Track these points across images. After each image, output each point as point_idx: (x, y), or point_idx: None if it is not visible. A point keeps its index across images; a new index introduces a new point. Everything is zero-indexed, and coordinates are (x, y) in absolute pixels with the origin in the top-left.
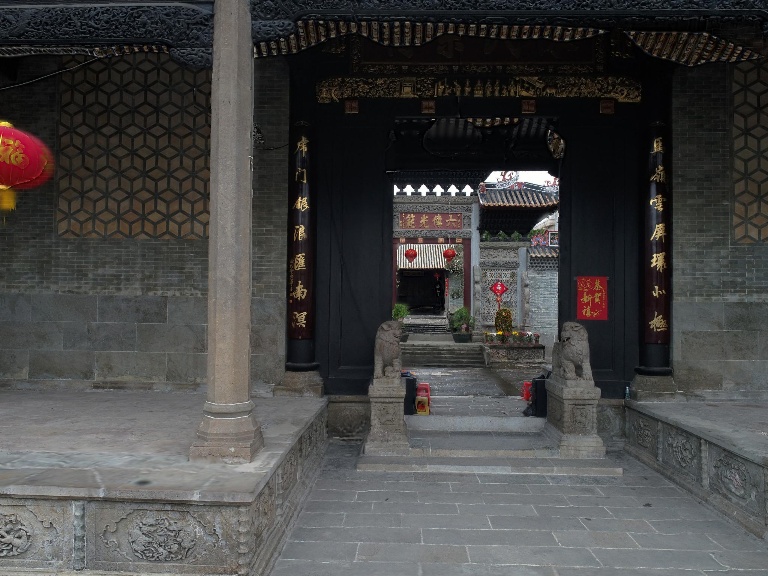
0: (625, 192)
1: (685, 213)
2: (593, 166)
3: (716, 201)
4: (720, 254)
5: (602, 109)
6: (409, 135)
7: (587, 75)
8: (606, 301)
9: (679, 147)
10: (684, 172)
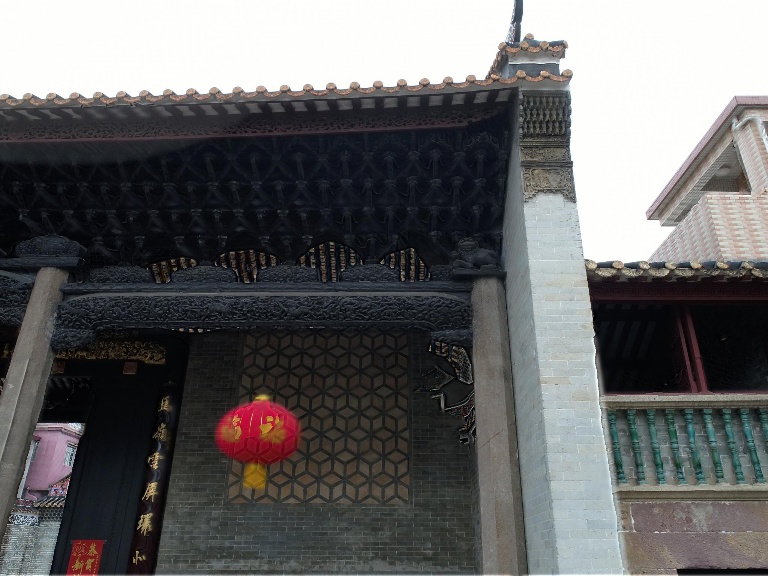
0: (138, 449)
1: (183, 471)
2: (113, 423)
3: (215, 459)
4: (211, 515)
5: (125, 370)
6: (86, 388)
7: (118, 340)
8: (97, 568)
9: (187, 405)
10: (188, 430)
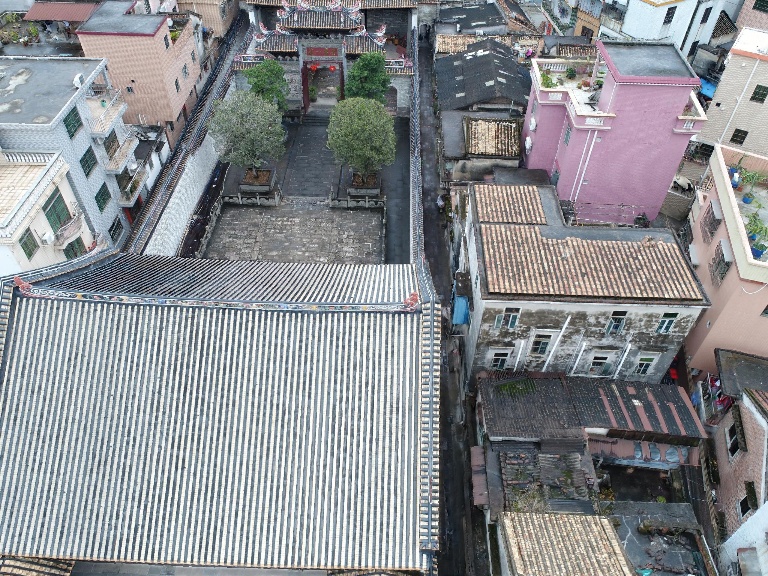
0: None
1: None
2: None
3: None
4: None
5: None
6: None
7: None
8: None
9: None
10: None
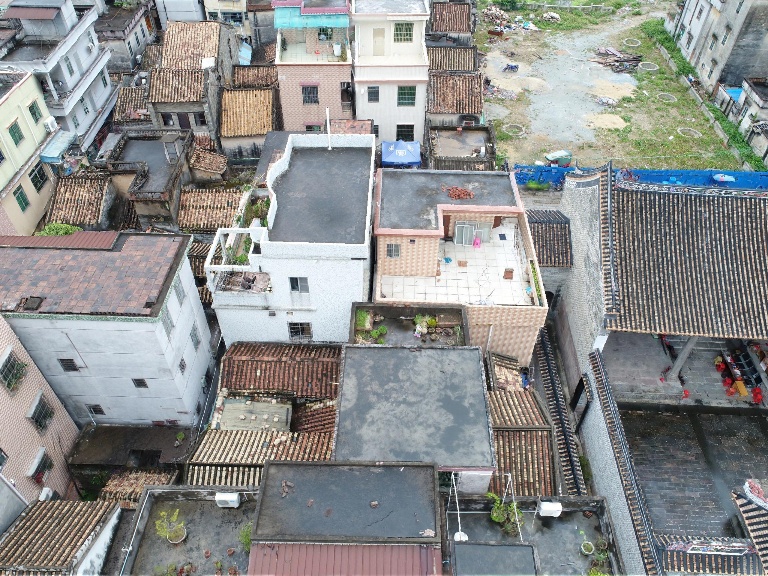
0: None
1: None
2: None
3: None
4: None
5: None
6: None
7: None
8: None
9: None
10: None
